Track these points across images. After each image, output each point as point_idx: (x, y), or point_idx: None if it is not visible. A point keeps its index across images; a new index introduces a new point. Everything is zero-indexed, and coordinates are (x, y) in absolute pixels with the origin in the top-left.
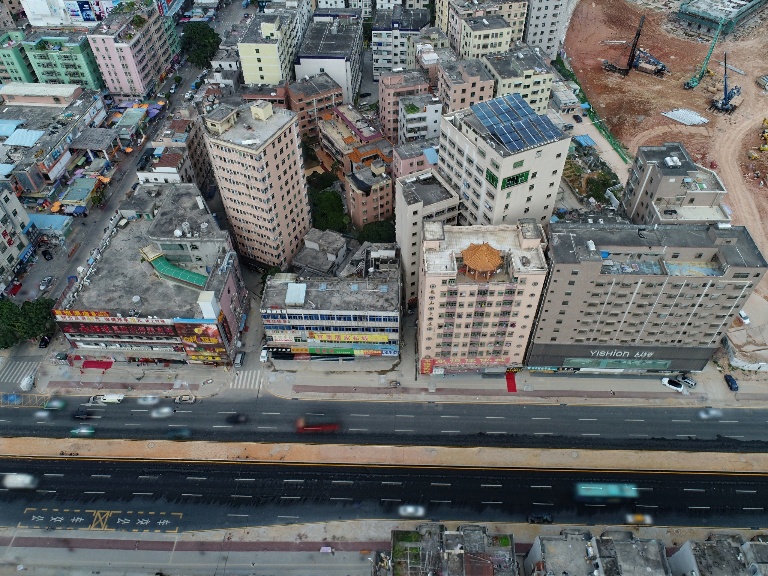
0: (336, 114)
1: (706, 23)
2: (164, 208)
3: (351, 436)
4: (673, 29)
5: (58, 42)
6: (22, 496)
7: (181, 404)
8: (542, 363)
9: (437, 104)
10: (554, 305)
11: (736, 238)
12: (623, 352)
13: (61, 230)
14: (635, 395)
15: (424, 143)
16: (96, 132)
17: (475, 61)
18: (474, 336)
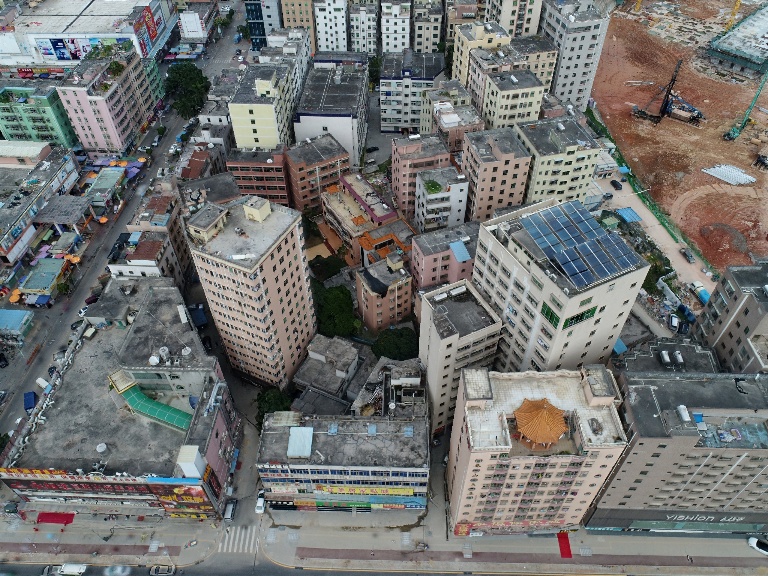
0: (342, 185)
1: (740, 62)
2: (138, 322)
3: None
4: (703, 67)
5: (24, 93)
6: None
7: None
8: (604, 524)
9: (463, 183)
10: (629, 474)
11: None
12: (707, 517)
13: (19, 330)
14: (718, 562)
15: (449, 232)
16: (65, 201)
17: (506, 130)
18: (524, 503)
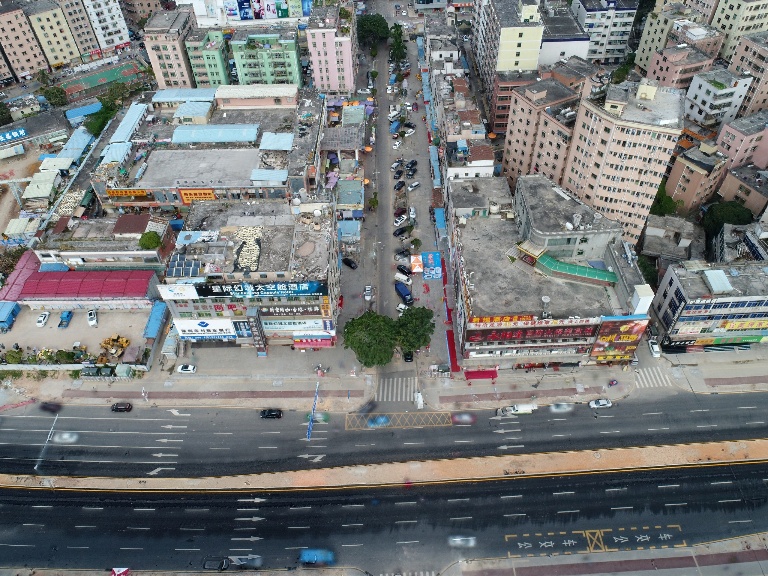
0: None
1: None
2: (528, 202)
3: None
4: None
5: (265, 40)
6: (492, 523)
7: (599, 409)
8: None
9: (749, 78)
10: None
11: None
12: None
13: (360, 236)
14: None
15: (751, 118)
16: (339, 132)
17: None
18: None
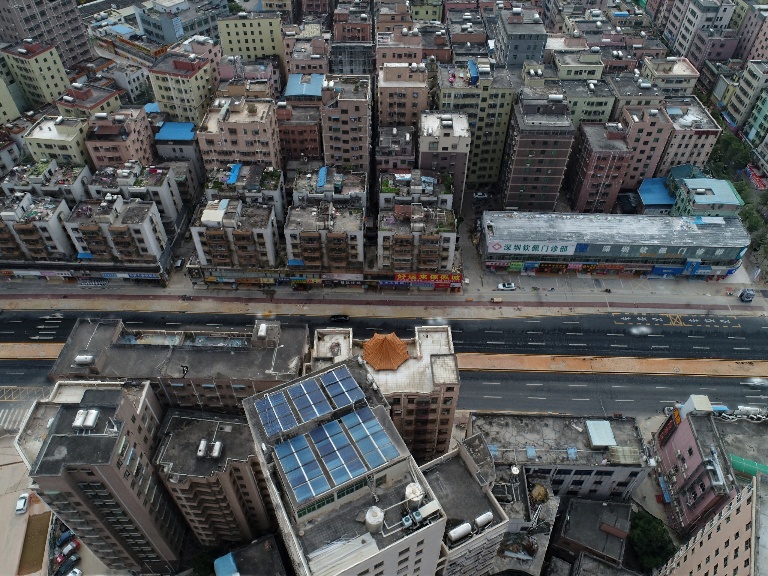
0: None
1: None
2: None
3: (497, 377)
4: None
5: None
6: (753, 335)
7: None
8: None
9: None
10: None
11: (82, 350)
12: None
13: None
14: None
15: None
16: None
17: None
18: None
